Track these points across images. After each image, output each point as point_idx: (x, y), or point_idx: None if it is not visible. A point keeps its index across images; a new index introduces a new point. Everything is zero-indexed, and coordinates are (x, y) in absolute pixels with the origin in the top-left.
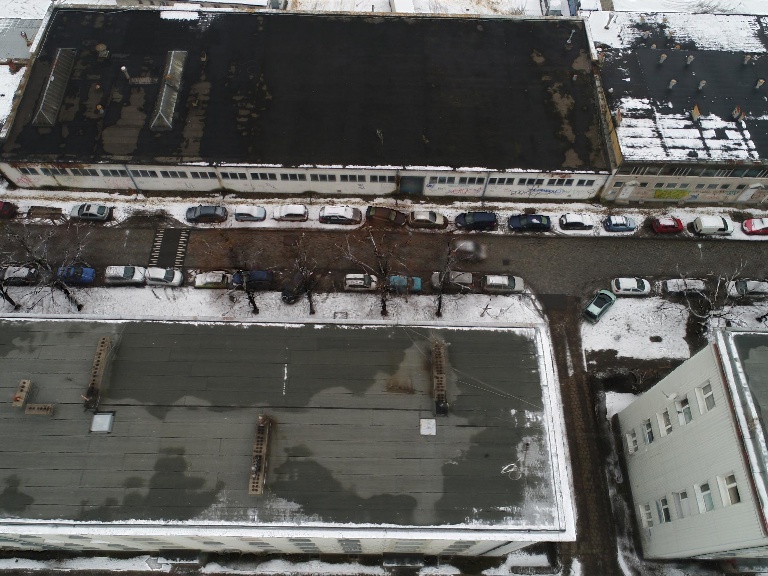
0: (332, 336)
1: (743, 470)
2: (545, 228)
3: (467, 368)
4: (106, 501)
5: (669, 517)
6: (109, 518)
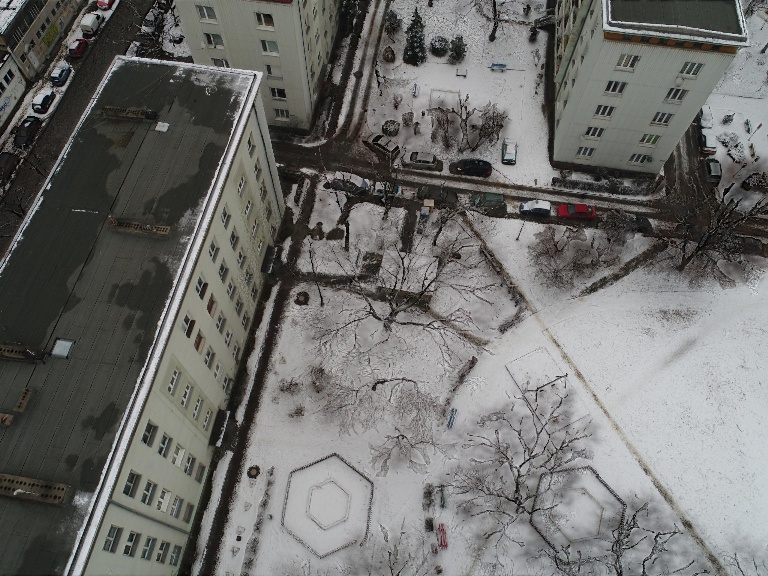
0: (62, 178)
1: (253, 2)
2: (38, 122)
3: (129, 100)
4: (136, 343)
5: (282, 90)
6: (151, 340)
